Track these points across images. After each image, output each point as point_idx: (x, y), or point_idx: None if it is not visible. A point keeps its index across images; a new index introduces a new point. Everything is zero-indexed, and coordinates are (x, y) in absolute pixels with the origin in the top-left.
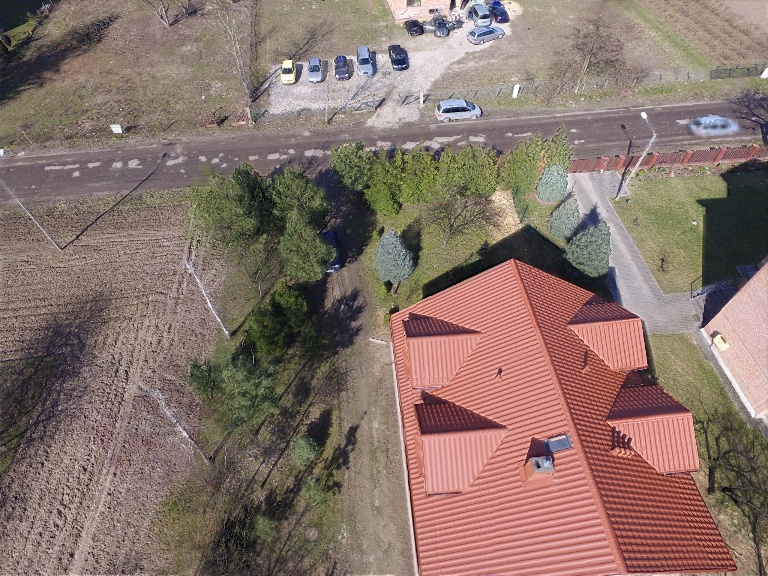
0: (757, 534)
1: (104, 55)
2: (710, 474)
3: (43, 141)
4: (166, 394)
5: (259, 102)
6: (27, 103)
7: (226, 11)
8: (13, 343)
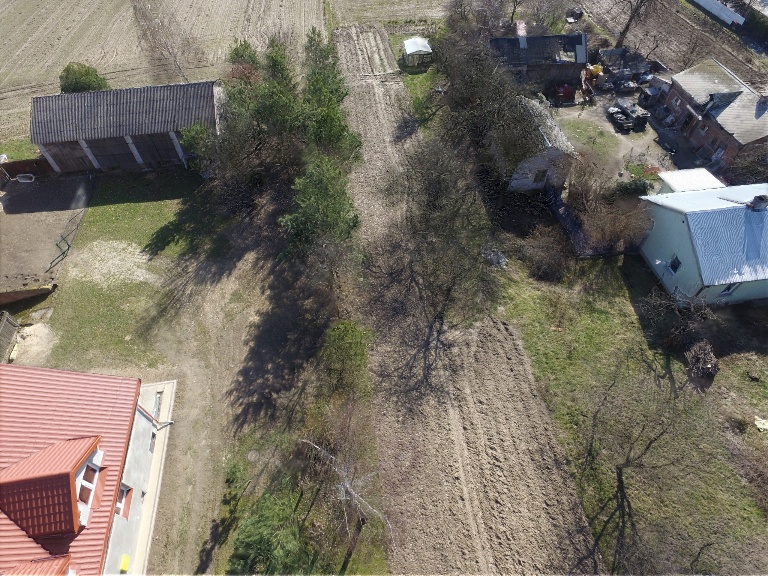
0: None
1: None
2: None
3: None
4: None
5: None
6: None
7: None
8: None
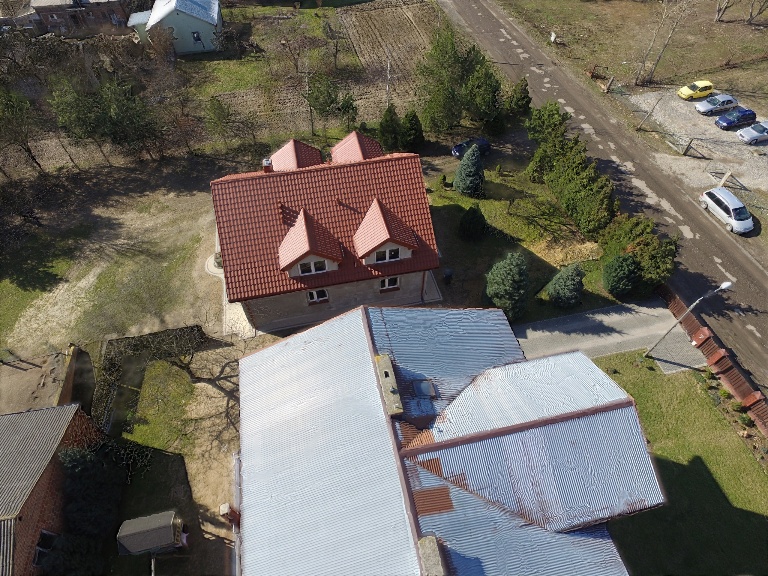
0: None
1: (645, 9)
2: None
3: (527, 20)
4: None
5: (640, 88)
6: (562, 3)
7: (686, 1)
8: (372, 62)
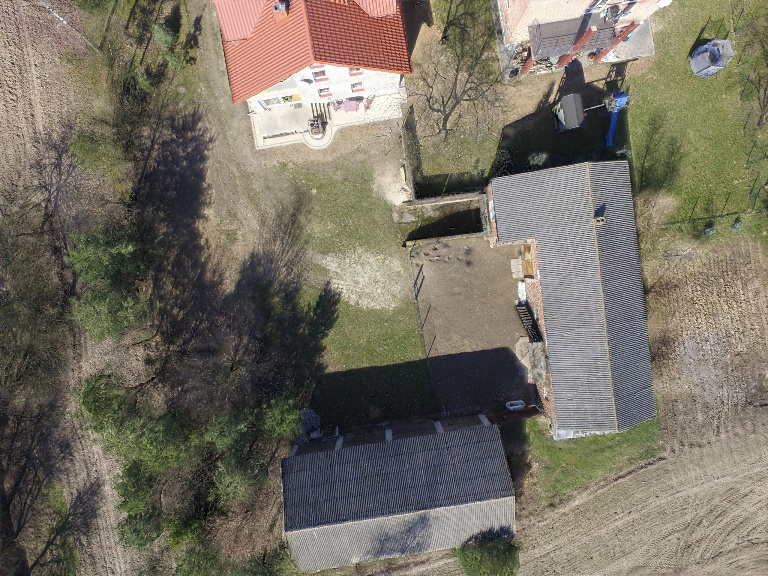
0: (460, 66)
1: None
2: (444, 31)
3: None
4: (47, 2)
5: None
6: None
7: None
8: None
